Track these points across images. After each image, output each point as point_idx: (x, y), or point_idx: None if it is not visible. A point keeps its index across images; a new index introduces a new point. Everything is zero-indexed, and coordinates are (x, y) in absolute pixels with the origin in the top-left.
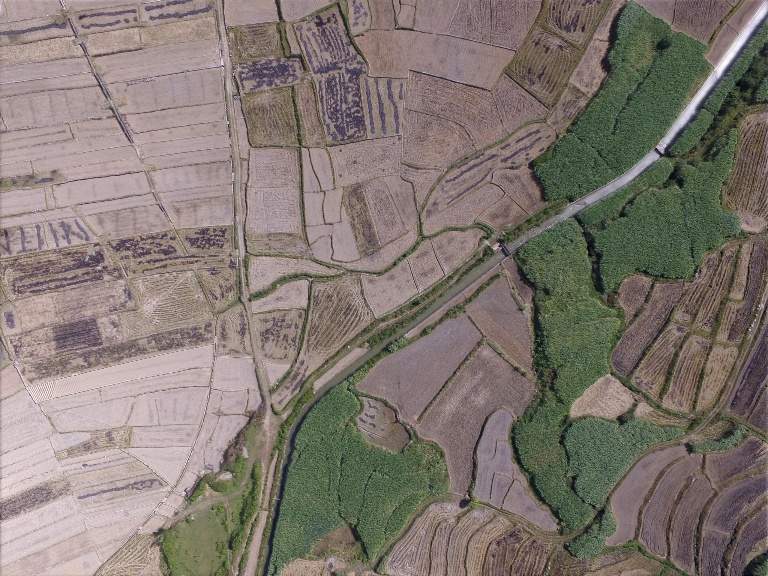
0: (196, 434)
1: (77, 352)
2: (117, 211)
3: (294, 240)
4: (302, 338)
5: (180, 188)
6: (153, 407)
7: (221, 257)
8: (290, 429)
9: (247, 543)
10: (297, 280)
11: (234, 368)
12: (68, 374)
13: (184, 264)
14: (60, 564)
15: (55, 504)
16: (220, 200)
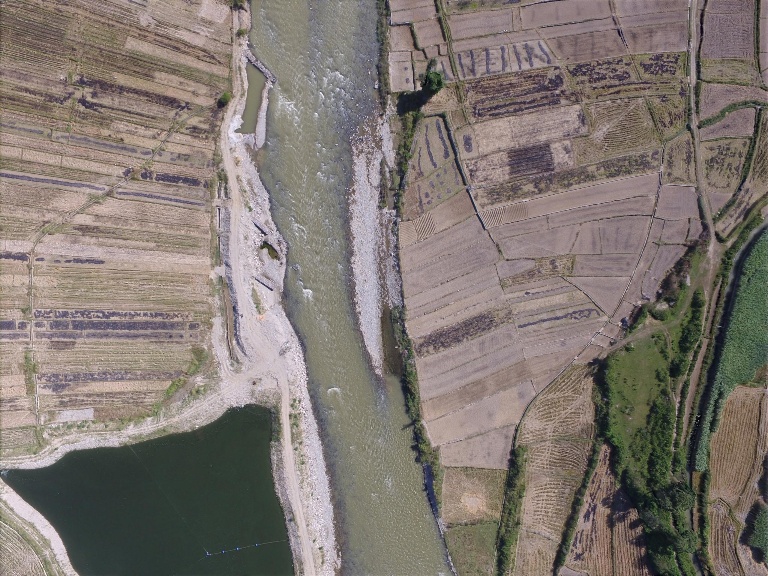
0: (635, 263)
1: (529, 178)
2: (576, 35)
3: (746, 67)
4: (747, 166)
5: (638, 13)
6: (596, 235)
7: (672, 84)
8: (735, 256)
9: (691, 369)
10: (745, 108)
11: (677, 197)
12: (518, 200)
13: (637, 90)
14: (496, 394)
15: (496, 332)
16: (675, 26)
